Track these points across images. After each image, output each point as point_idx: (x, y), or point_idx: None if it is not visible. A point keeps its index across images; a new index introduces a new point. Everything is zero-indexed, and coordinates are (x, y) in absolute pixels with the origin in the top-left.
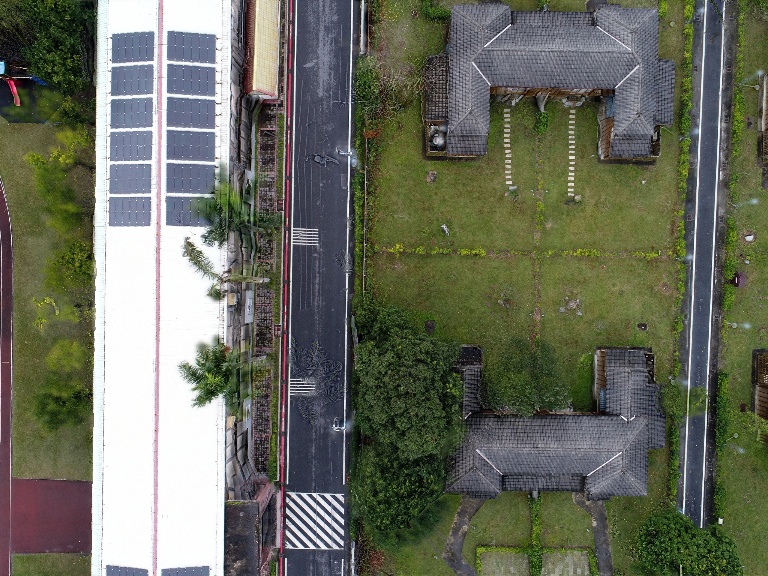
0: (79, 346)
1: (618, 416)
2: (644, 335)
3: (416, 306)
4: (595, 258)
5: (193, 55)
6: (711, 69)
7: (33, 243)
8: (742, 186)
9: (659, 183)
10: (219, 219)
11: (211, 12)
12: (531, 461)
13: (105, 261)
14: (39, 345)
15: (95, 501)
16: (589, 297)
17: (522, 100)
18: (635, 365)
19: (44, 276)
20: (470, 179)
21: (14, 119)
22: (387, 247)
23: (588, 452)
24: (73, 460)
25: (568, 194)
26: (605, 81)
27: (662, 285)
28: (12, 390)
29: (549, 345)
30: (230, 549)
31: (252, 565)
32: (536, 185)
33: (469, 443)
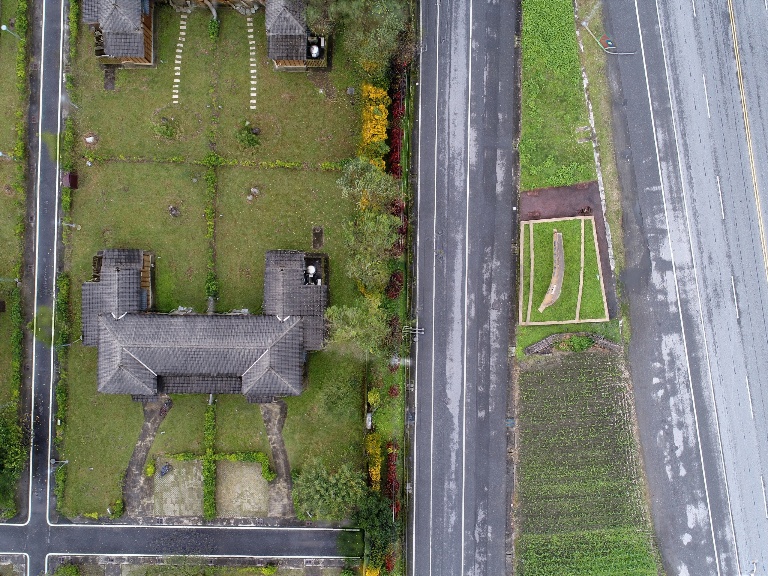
0: None
1: None
2: None
3: None
4: None
5: None
6: None
7: None
8: (84, 88)
9: (3, 85)
10: None
11: None
12: None
13: None
14: None
15: None
16: None
17: None
18: None
19: None
20: None
21: None
22: None
23: None
24: None
25: None
26: None
27: (5, 187)
28: None
29: None
30: None
31: None
32: None
33: None
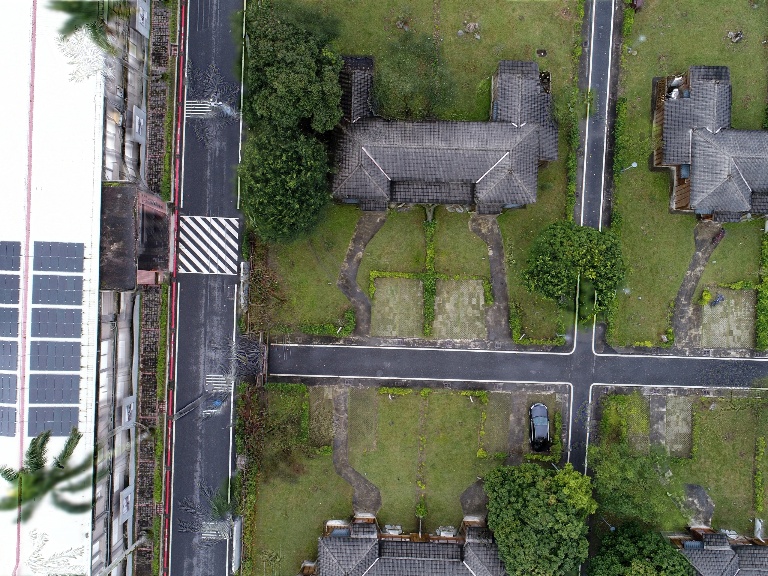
0: None
1: (508, 122)
2: (543, 61)
3: (314, 28)
4: None
5: None
6: None
7: None
8: None
9: None
10: None
11: None
12: (418, 162)
13: None
14: None
15: None
16: (488, 22)
17: None
18: (528, 75)
19: None
20: None
21: None
22: None
23: (475, 151)
24: None
25: None
26: None
27: (562, 10)
28: None
29: (447, 70)
30: (107, 231)
31: (129, 248)
32: None
33: (355, 140)
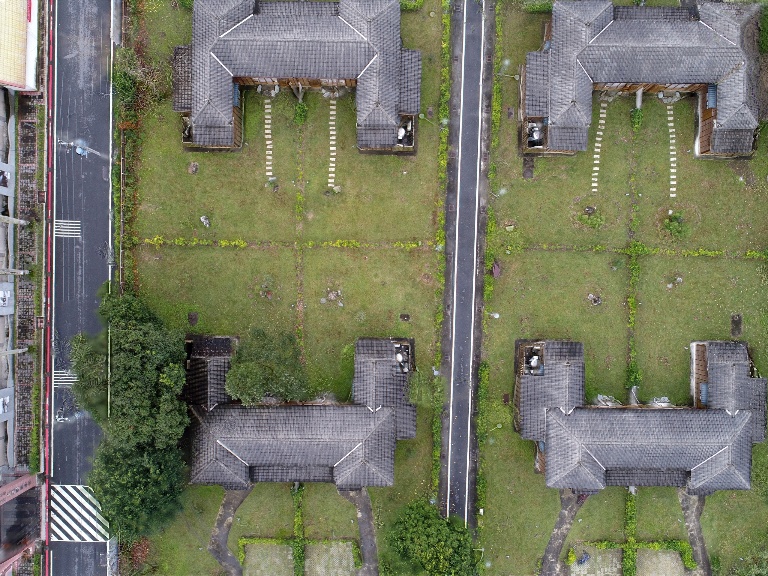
0: None
1: (364, 406)
2: (407, 326)
3: (178, 298)
4: (356, 249)
5: None
6: (471, 59)
7: None
8: (503, 176)
9: (420, 174)
10: None
11: None
12: (274, 452)
13: None
14: None
15: None
16: (351, 288)
17: (282, 91)
18: (384, 355)
19: None
20: (231, 170)
21: None
22: (149, 239)
23: (328, 442)
24: None
25: (328, 185)
26: (346, 71)
27: (424, 276)
28: None
29: (312, 336)
30: None
31: None
32: (297, 176)
33: (209, 434)
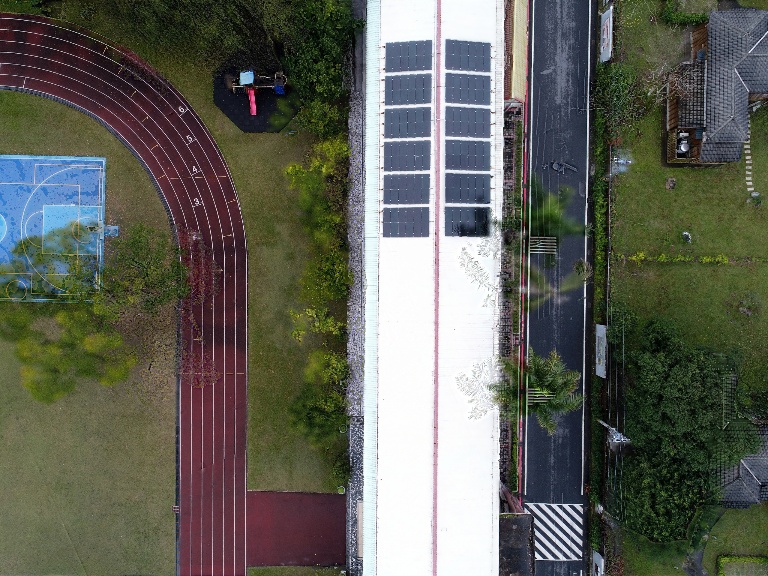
0: (315, 357)
1: None
2: None
3: (656, 314)
4: None
5: (470, 64)
6: None
7: (268, 253)
8: None
9: None
10: (494, 229)
11: (486, 20)
12: None
13: (378, 272)
14: (274, 356)
15: (369, 515)
16: None
17: (763, 106)
18: None
19: (279, 286)
20: (710, 186)
21: (249, 128)
22: (626, 255)
23: None
24: (309, 472)
25: None
26: None
27: None
28: (247, 402)
29: None
30: (503, 562)
31: None
32: None
33: (733, 453)
